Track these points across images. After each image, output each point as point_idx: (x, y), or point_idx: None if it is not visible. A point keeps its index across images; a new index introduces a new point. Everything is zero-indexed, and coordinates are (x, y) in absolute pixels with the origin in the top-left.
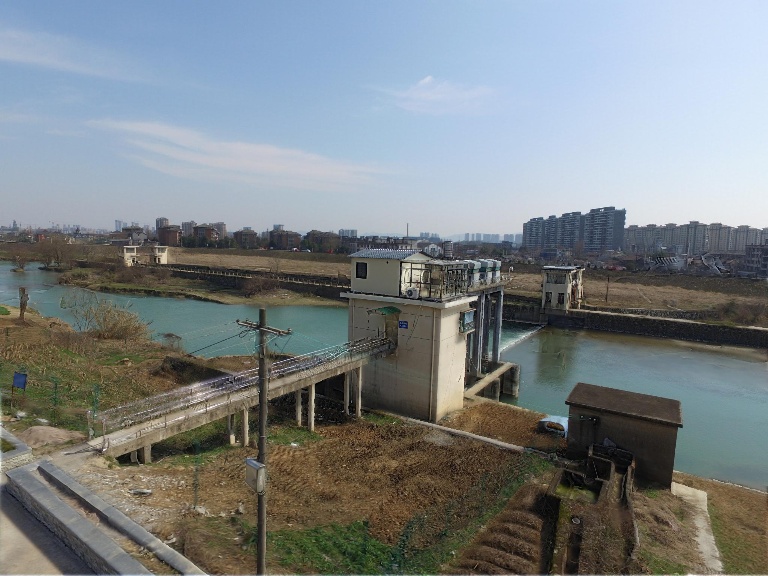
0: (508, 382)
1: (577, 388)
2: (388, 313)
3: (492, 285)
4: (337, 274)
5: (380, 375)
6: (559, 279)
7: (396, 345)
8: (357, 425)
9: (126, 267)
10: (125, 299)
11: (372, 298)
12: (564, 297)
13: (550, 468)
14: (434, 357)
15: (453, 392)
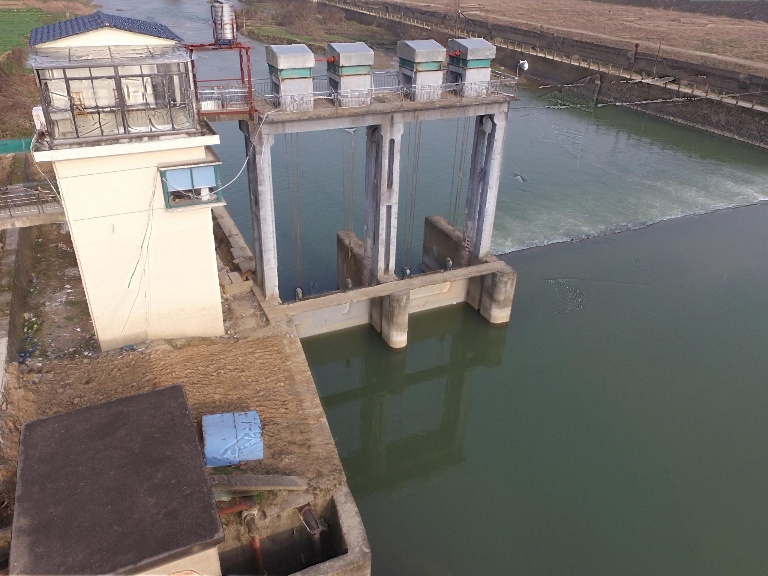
0: (487, 297)
1: (129, 399)
2: (5, 152)
3: (420, 103)
4: (572, 28)
5: None
6: None
7: None
8: None
9: (311, 2)
10: (260, 50)
11: None
12: None
13: None
14: None
15: (169, 308)
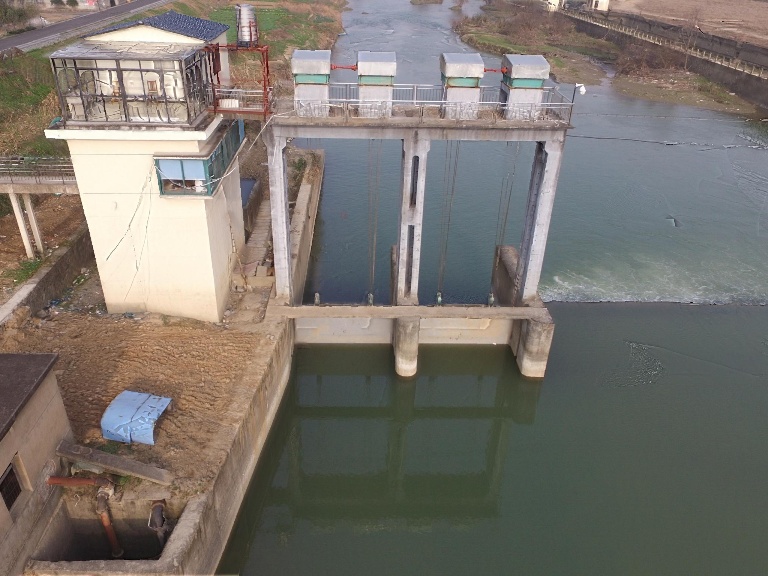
0: (522, 345)
1: (8, 356)
2: None
3: (446, 121)
4: None
5: None
6: None
7: None
8: (6, 264)
9: (548, 12)
10: None
11: None
12: None
13: None
14: None
15: (167, 287)
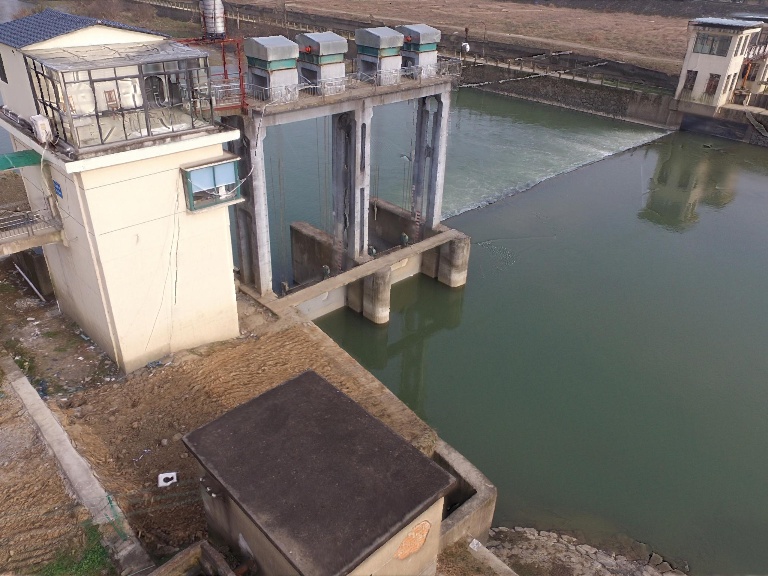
0: (445, 264)
1: (273, 392)
2: None
3: (388, 87)
4: (391, 17)
5: (66, 271)
6: (723, 45)
7: (61, 226)
8: None
9: None
10: None
11: (8, 128)
12: (719, 82)
13: (93, 575)
14: (98, 263)
15: (190, 316)
